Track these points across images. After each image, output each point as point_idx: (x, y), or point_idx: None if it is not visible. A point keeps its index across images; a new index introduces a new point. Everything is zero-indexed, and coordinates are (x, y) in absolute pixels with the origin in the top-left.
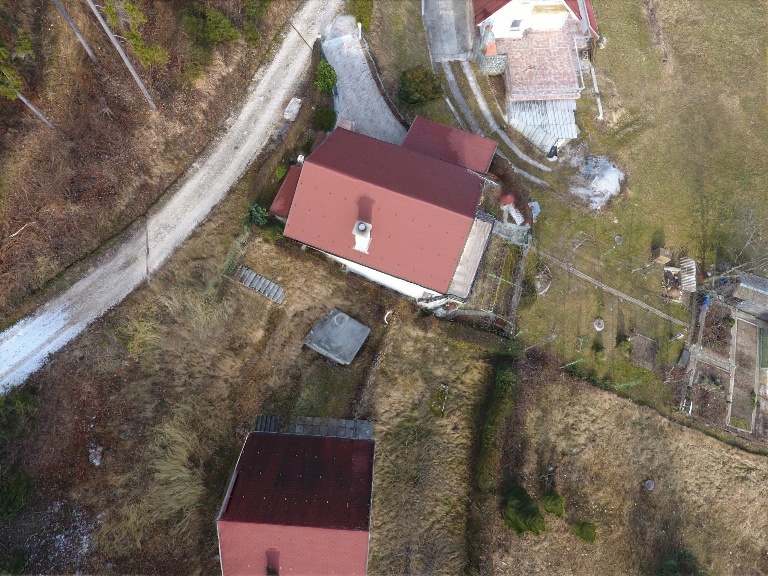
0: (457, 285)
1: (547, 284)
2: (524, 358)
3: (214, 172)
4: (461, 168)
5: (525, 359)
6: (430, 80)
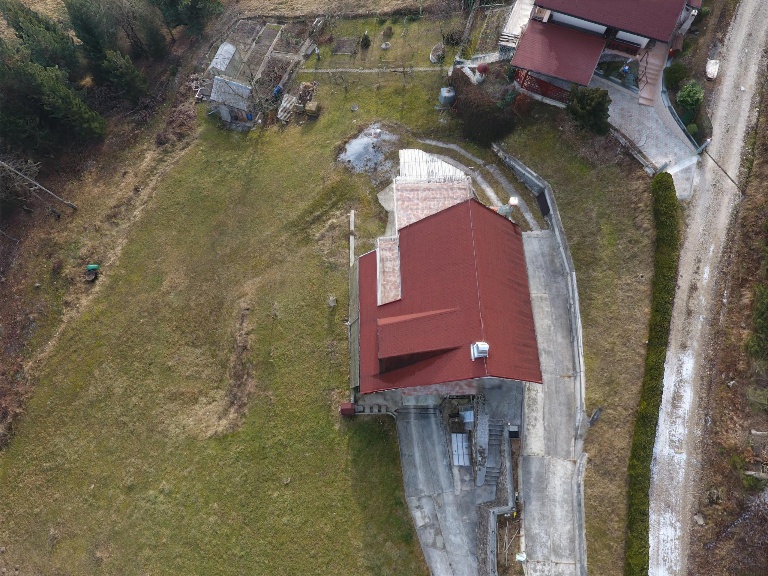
0: (527, 2)
1: (436, 47)
2: (458, 3)
3: (762, 11)
4: (557, 6)
5: (458, 2)
6: (586, 99)
